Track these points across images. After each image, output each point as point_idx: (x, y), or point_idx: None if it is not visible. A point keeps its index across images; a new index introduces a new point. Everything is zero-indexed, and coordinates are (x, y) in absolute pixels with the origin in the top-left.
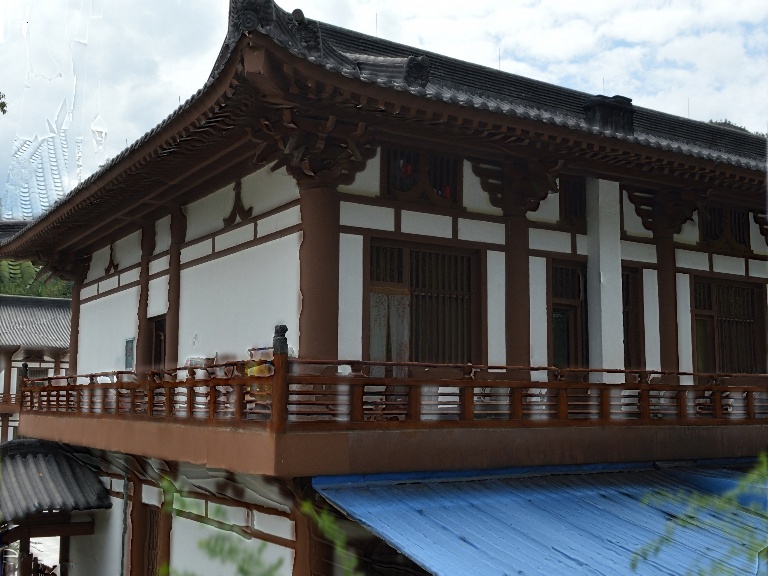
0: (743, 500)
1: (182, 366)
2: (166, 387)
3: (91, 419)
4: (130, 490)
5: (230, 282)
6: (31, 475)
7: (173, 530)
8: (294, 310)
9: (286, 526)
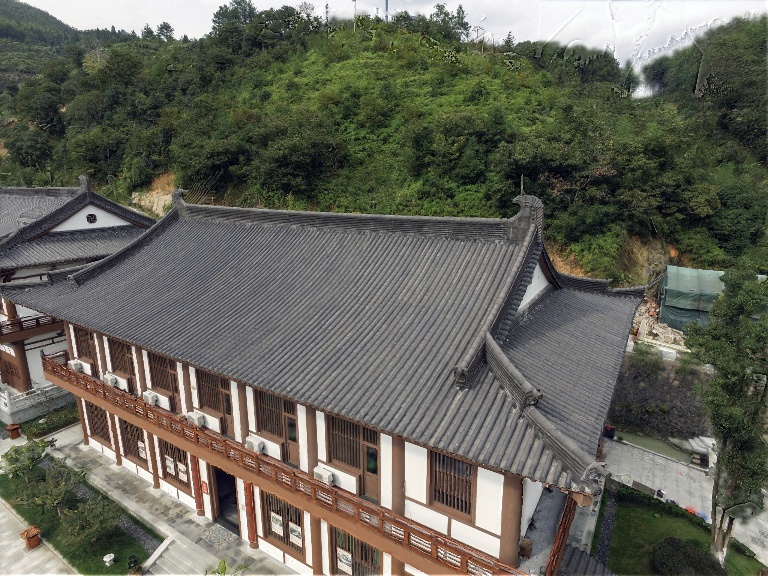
0: None
1: None
2: None
3: None
4: None
5: None
6: (572, 571)
7: None
8: None
9: None
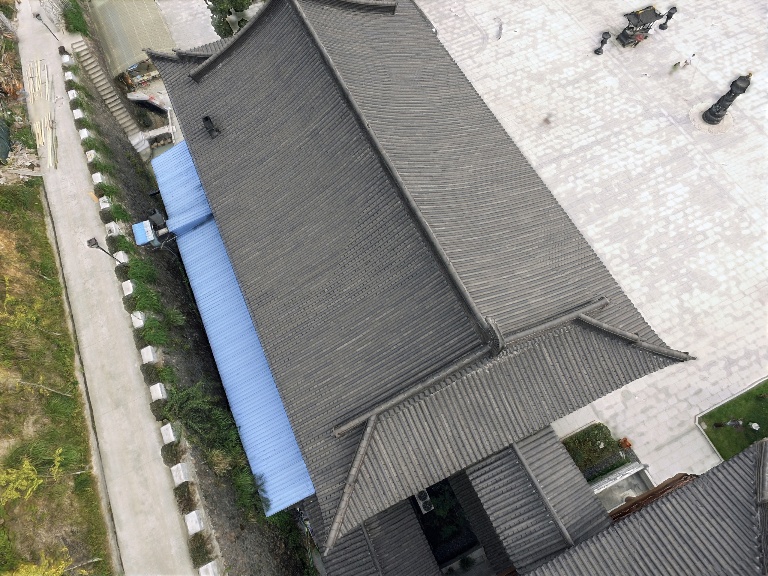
0: None
1: None
2: None
3: None
4: None
5: None
6: None
7: None
8: None
9: None
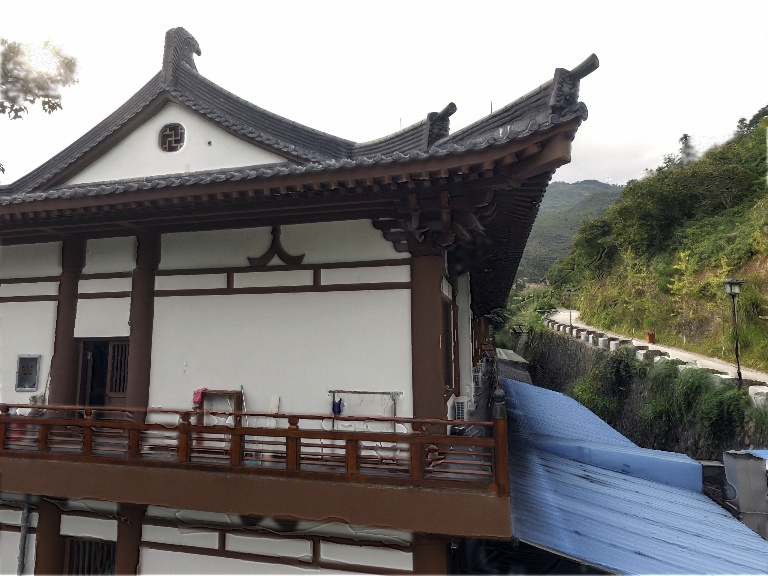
0: (568, 454)
1: (159, 393)
2: (230, 433)
3: (11, 459)
4: (31, 522)
5: (266, 319)
6: None
7: (145, 565)
8: (400, 358)
9: (391, 556)
